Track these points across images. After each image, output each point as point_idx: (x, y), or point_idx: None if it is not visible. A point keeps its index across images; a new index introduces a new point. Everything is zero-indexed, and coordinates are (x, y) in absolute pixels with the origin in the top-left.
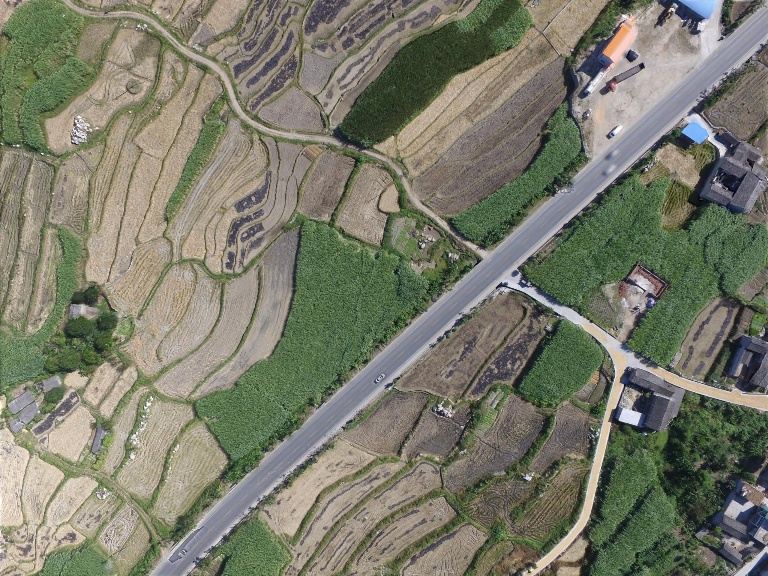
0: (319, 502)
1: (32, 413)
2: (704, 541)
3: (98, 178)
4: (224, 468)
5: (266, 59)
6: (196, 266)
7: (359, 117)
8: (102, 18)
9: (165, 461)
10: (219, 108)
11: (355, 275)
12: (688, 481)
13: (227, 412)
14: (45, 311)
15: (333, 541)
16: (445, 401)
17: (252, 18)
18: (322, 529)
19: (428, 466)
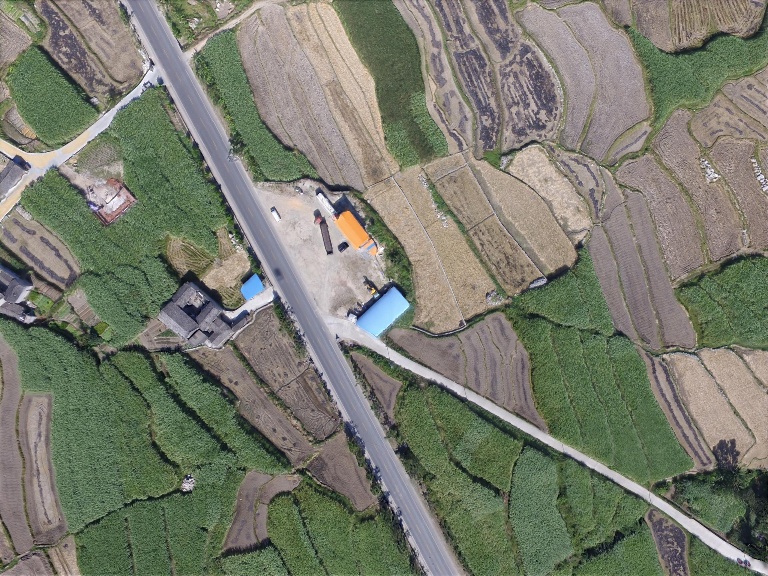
0: None
1: None
2: None
3: None
4: None
5: None
6: None
7: None
8: None
9: None
10: None
11: None
12: None
13: None
14: None
15: None
16: None
17: None
18: None
19: None
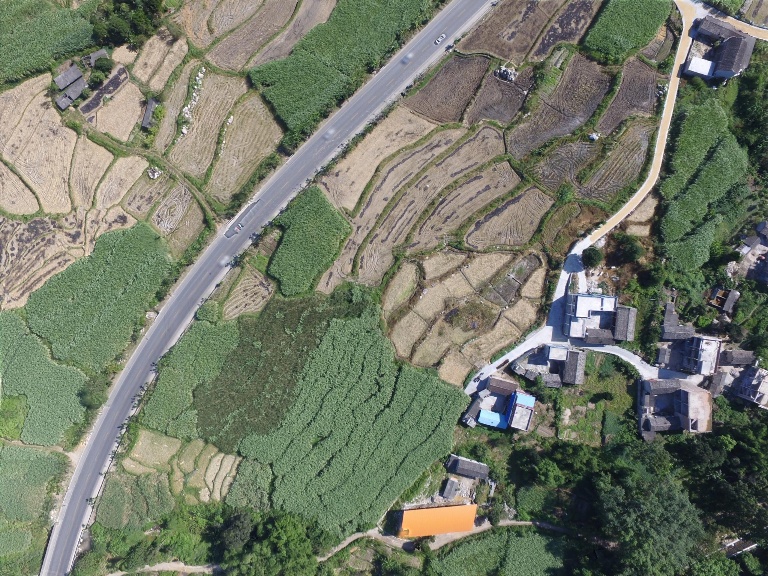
0: (379, 171)
1: (80, 88)
2: None
3: None
4: (280, 142)
5: None
6: None
7: None
8: None
9: (218, 136)
10: None
11: None
12: (760, 130)
13: (283, 77)
14: None
15: (394, 211)
16: (508, 63)
17: None
18: (382, 200)
19: (491, 131)
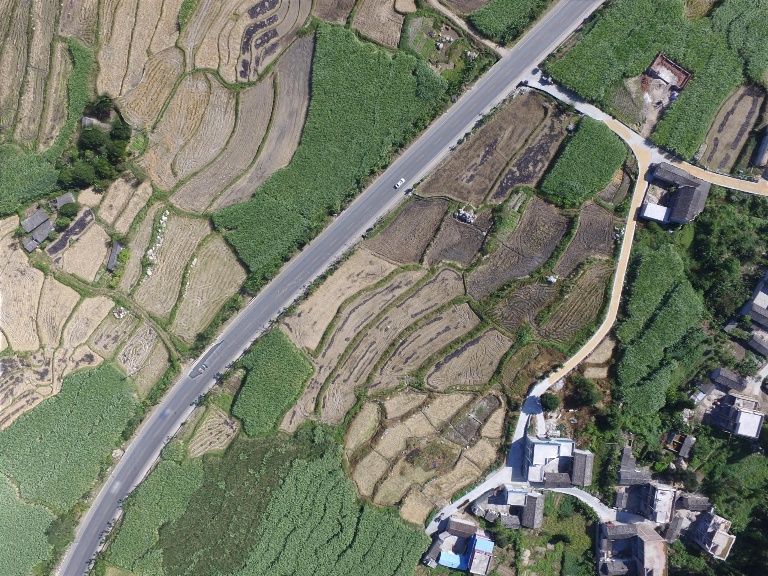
0: (340, 312)
1: (46, 231)
2: (733, 334)
3: None
4: (243, 282)
5: None
6: (210, 76)
7: None
8: None
9: (183, 277)
10: None
11: (372, 77)
12: (716, 275)
13: (245, 221)
14: (56, 129)
15: (356, 352)
16: (466, 206)
17: None
18: (344, 340)
19: (450, 273)
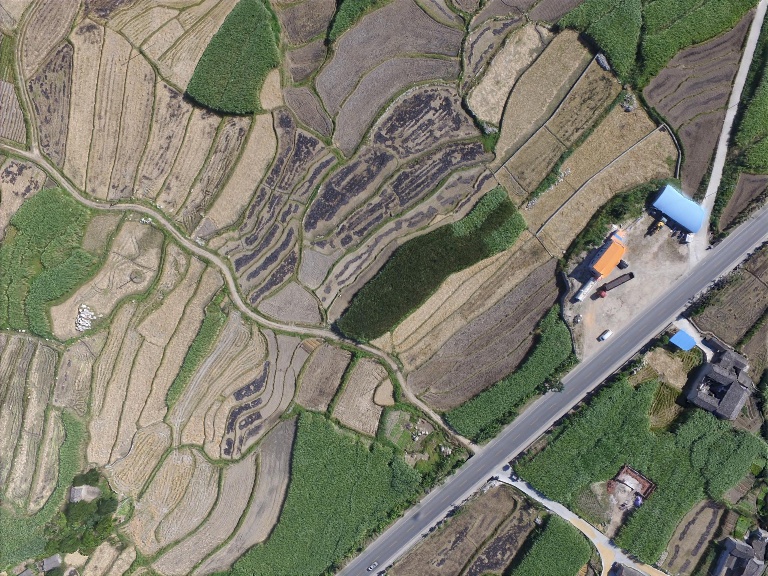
0: None
1: None
2: None
3: (101, 364)
4: None
5: (266, 254)
6: (195, 451)
7: (356, 317)
8: (108, 210)
9: None
10: (220, 300)
11: (350, 467)
12: None
13: None
14: (47, 489)
15: None
16: None
17: (253, 214)
18: None
19: None
